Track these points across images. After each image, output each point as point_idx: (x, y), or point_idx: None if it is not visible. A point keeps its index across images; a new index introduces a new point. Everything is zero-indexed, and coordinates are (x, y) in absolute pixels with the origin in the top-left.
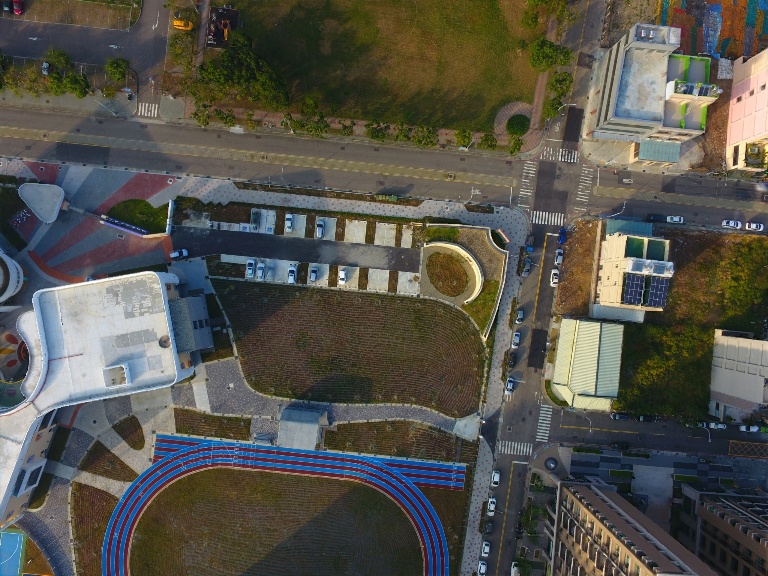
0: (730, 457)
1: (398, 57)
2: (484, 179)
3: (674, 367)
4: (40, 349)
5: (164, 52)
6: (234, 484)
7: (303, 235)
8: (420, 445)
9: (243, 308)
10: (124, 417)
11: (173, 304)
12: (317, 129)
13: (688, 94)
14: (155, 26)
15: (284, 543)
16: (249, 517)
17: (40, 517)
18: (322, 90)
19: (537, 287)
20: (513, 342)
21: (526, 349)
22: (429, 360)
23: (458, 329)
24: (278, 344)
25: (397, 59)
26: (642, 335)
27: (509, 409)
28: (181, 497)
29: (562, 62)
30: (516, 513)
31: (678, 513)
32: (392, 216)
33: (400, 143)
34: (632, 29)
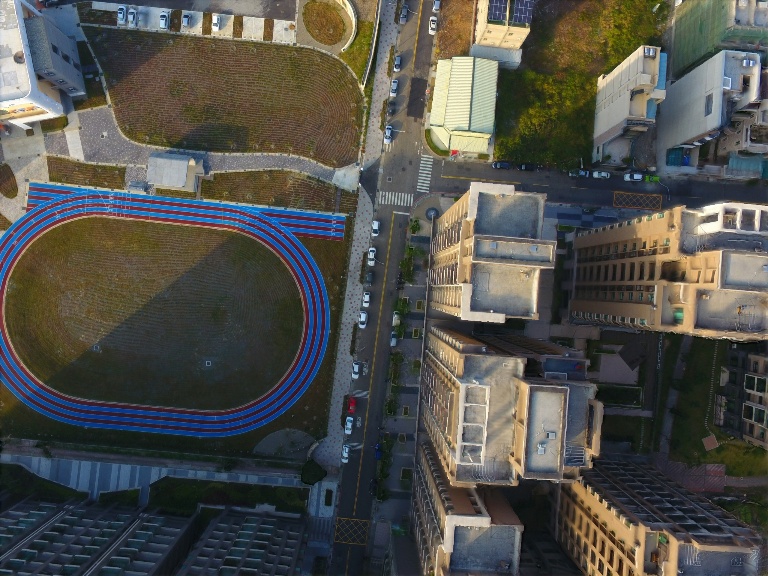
0: (615, 208)
1: None
2: None
3: (556, 116)
4: None
5: None
6: (110, 234)
7: None
8: (299, 195)
9: (116, 56)
10: None
11: (29, 22)
12: None
13: None
14: None
15: (162, 294)
16: (126, 267)
17: None
18: None
19: (416, 35)
20: (391, 89)
21: (405, 98)
22: (306, 109)
23: (336, 78)
24: (152, 92)
25: None
26: (523, 82)
27: (389, 159)
28: (56, 247)
29: None
30: (397, 264)
31: (562, 263)
32: None
33: None
34: None
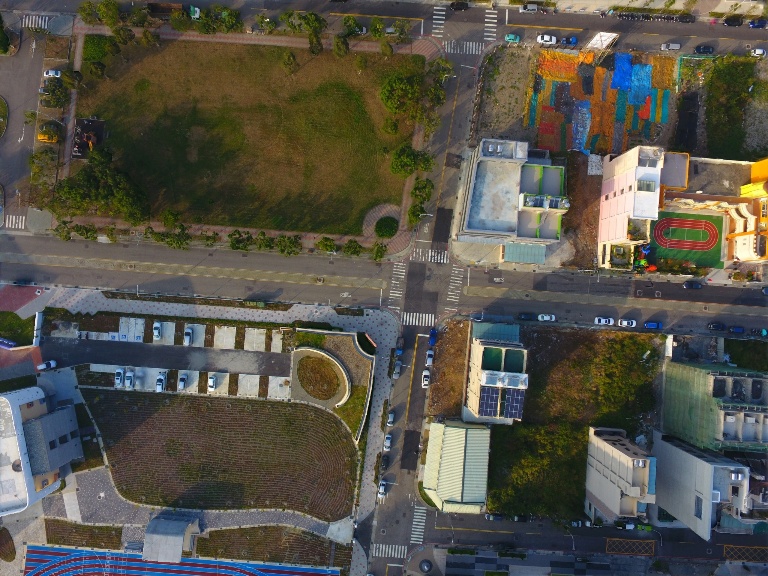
0: (608, 555)
1: (265, 163)
2: (353, 282)
3: (549, 466)
4: None
5: None
6: None
7: (172, 342)
8: (293, 550)
9: (113, 417)
10: None
11: (27, 426)
12: (177, 242)
13: (538, 207)
14: (21, 139)
15: None
16: None
17: None
18: (189, 198)
19: (409, 388)
20: (384, 445)
21: (399, 451)
22: (301, 464)
23: (330, 432)
24: (148, 452)
25: (264, 165)
26: (515, 435)
27: (383, 512)
28: None
29: (423, 169)
30: None
31: None
32: (261, 321)
33: None
34: (481, 143)
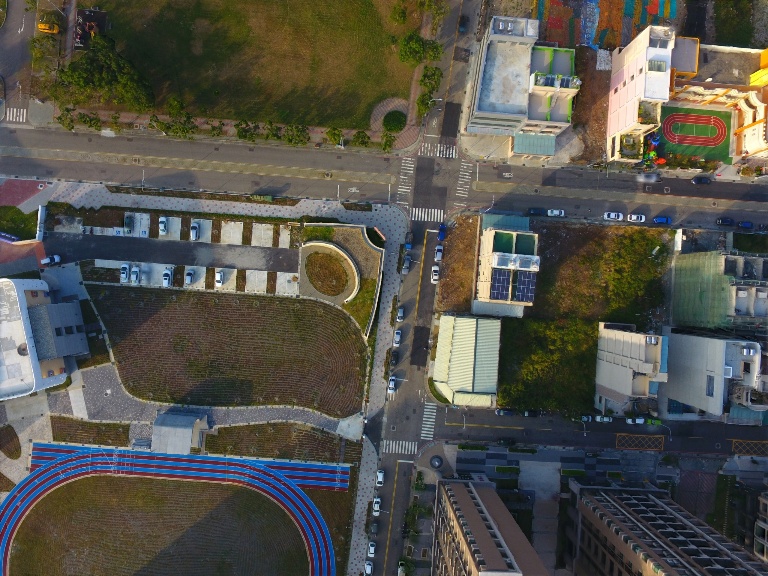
0: (618, 450)
1: (271, 56)
2: (361, 177)
3: (558, 361)
4: None
5: (31, 56)
6: (114, 491)
7: (178, 238)
8: (303, 447)
9: (119, 313)
10: None
11: (33, 311)
12: (183, 130)
13: (549, 86)
14: (21, 30)
15: (167, 549)
16: (131, 524)
17: None
18: (194, 91)
19: (418, 284)
20: (394, 340)
21: (408, 347)
22: (310, 361)
23: (339, 329)
24: (155, 348)
25: (270, 58)
26: (525, 330)
27: (393, 408)
28: (60, 506)
29: (431, 57)
30: (402, 512)
31: (566, 508)
32: (269, 216)
33: (275, 142)
34: (491, 22)
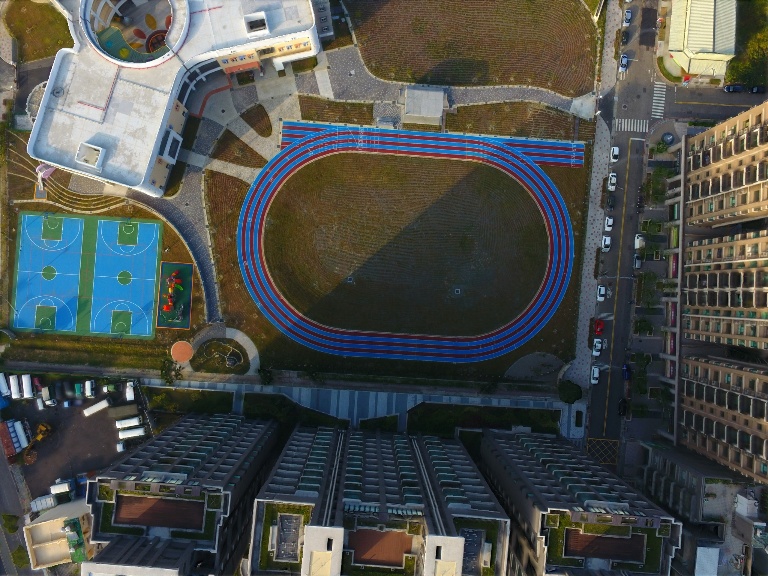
0: None
1: None
2: None
3: None
4: (181, 3)
5: None
6: (360, 168)
7: None
8: (538, 125)
9: None
10: (251, 106)
11: None
12: None
13: None
14: None
15: (411, 225)
16: (376, 201)
17: (176, 204)
18: None
19: None
20: (625, 19)
21: (637, 28)
22: (543, 42)
23: (569, 11)
24: (395, 31)
25: None
26: (751, 8)
27: (623, 87)
28: (309, 182)
29: None
30: (636, 188)
31: None
32: None
33: None
34: None
